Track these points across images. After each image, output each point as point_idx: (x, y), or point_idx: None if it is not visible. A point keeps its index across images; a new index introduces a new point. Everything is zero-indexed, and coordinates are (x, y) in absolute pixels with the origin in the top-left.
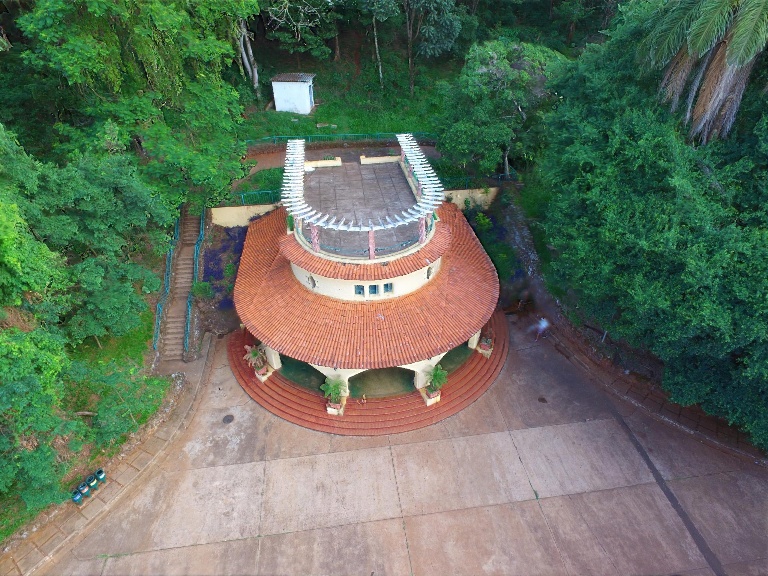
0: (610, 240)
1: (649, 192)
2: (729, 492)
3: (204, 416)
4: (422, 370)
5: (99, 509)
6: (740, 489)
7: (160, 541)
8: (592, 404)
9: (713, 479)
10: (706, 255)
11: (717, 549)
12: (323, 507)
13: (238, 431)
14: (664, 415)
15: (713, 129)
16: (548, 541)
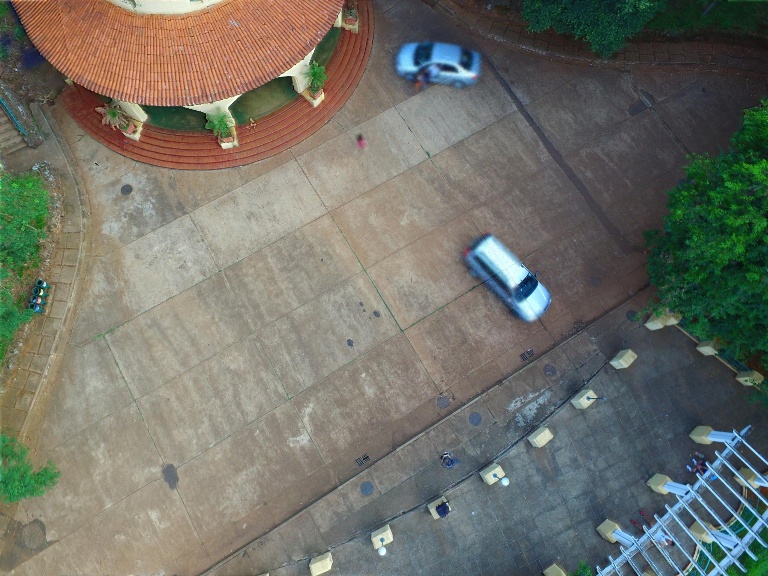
0: None
1: None
2: (570, 98)
3: (99, 196)
4: (299, 73)
5: (64, 308)
6: (578, 93)
7: (139, 307)
8: (461, 53)
9: (559, 91)
10: None
11: (560, 147)
12: (261, 230)
13: (144, 197)
14: (522, 44)
15: None
16: (443, 187)
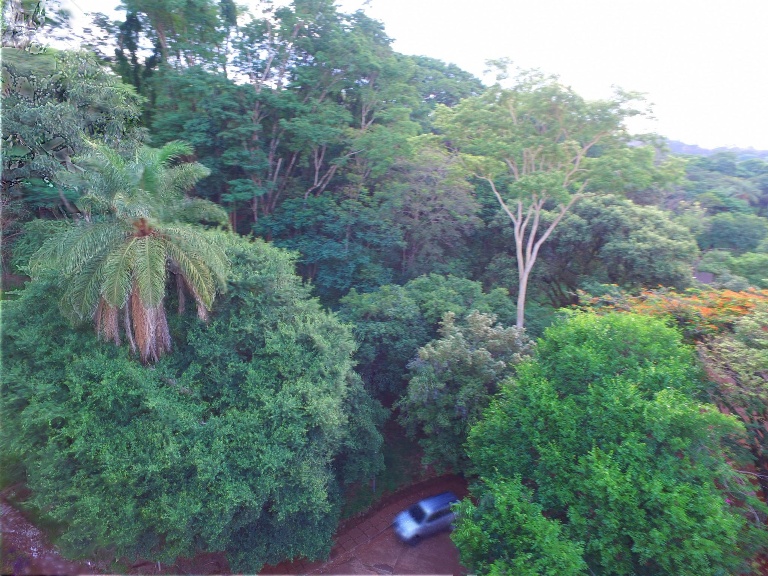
0: (119, 480)
1: (133, 418)
2: None
3: None
4: None
5: None
6: None
7: None
8: None
9: None
10: (206, 449)
11: None
12: None
13: None
14: None
15: (158, 348)
16: None
